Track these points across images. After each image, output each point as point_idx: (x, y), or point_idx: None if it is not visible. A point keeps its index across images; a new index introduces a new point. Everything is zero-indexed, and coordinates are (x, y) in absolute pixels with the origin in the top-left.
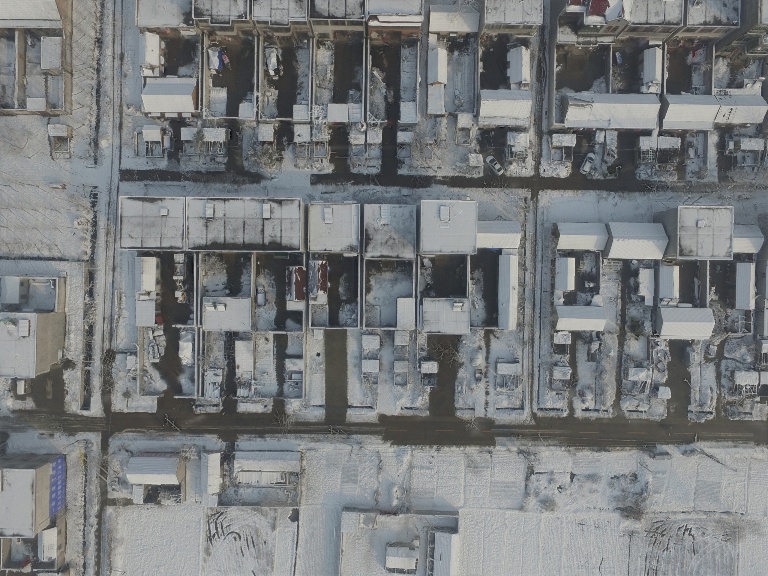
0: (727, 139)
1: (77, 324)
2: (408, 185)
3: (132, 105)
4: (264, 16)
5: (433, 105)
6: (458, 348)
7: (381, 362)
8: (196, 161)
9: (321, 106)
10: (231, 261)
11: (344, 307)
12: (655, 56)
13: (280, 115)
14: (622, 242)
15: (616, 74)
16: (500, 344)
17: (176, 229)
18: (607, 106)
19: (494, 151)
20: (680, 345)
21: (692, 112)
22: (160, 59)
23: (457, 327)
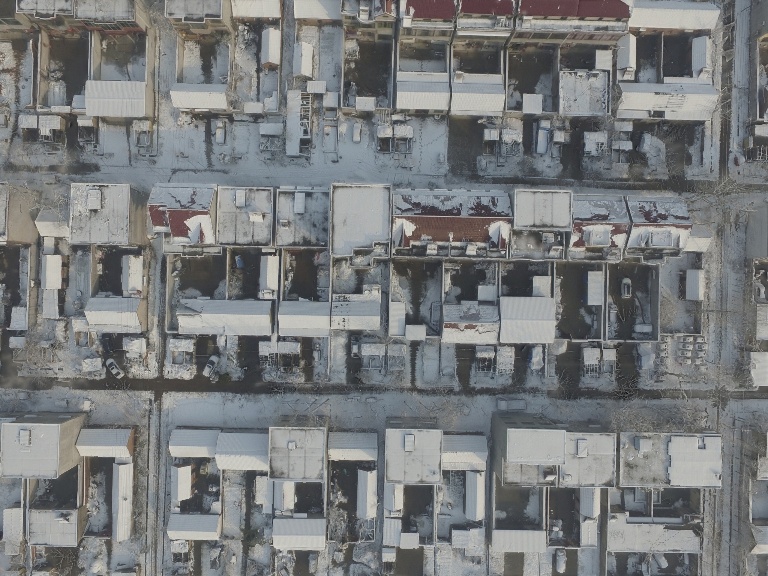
0: (352, 342)
1: None
2: (28, 387)
3: None
4: None
5: (47, 310)
6: (78, 554)
7: None
8: None
9: None
10: None
11: None
12: (266, 265)
13: None
14: (224, 457)
15: (234, 279)
16: (122, 549)
17: None
18: (216, 316)
19: (117, 353)
20: None
21: (304, 321)
22: None
23: (64, 539)
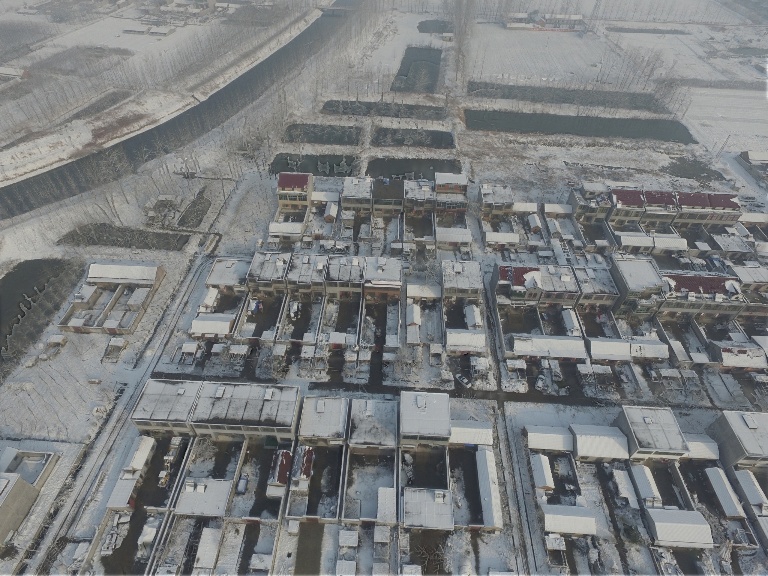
0: (649, 370)
1: (45, 505)
2: (391, 393)
3: (182, 330)
4: (294, 278)
5: (411, 338)
6: None
7: (358, 567)
8: (217, 368)
9: (325, 334)
10: (223, 450)
11: (324, 499)
12: (570, 314)
13: None
14: (585, 438)
15: (546, 325)
16: (490, 551)
17: (186, 405)
18: (543, 341)
19: (462, 371)
20: (689, 560)
21: (610, 347)
22: (214, 303)
23: (440, 521)
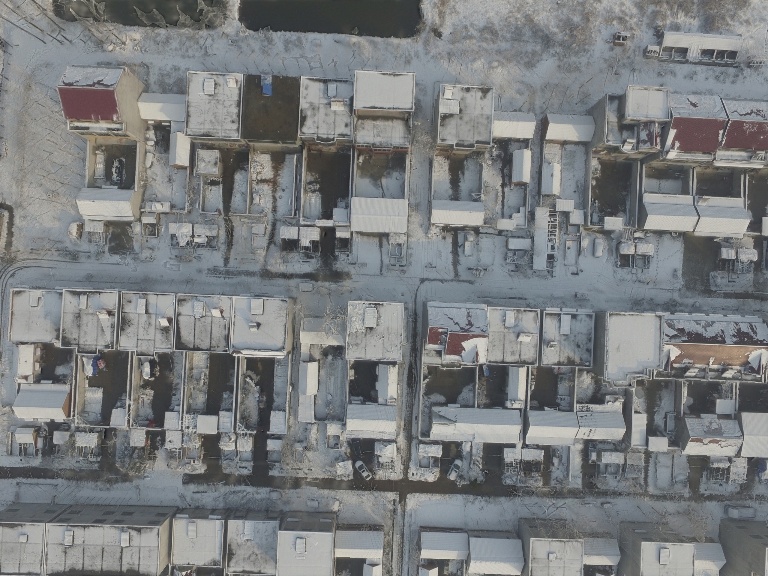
0: (590, 449)
1: None
2: (279, 486)
3: (7, 405)
4: (130, 346)
5: (303, 414)
6: None
7: None
8: (69, 460)
9: (192, 415)
10: None
11: None
12: (518, 376)
13: (155, 415)
14: (479, 563)
15: (482, 387)
16: None
17: (35, 555)
18: (470, 425)
19: (364, 455)
20: None
21: (553, 431)
22: (35, 366)
23: None
